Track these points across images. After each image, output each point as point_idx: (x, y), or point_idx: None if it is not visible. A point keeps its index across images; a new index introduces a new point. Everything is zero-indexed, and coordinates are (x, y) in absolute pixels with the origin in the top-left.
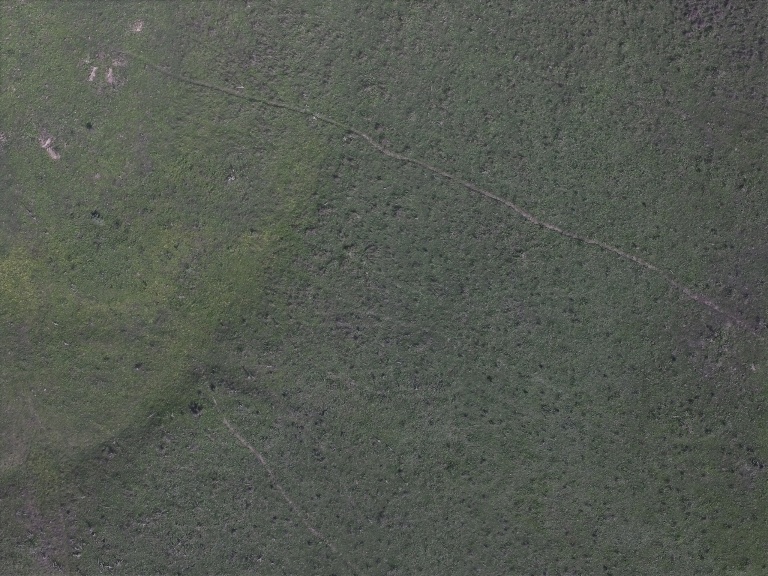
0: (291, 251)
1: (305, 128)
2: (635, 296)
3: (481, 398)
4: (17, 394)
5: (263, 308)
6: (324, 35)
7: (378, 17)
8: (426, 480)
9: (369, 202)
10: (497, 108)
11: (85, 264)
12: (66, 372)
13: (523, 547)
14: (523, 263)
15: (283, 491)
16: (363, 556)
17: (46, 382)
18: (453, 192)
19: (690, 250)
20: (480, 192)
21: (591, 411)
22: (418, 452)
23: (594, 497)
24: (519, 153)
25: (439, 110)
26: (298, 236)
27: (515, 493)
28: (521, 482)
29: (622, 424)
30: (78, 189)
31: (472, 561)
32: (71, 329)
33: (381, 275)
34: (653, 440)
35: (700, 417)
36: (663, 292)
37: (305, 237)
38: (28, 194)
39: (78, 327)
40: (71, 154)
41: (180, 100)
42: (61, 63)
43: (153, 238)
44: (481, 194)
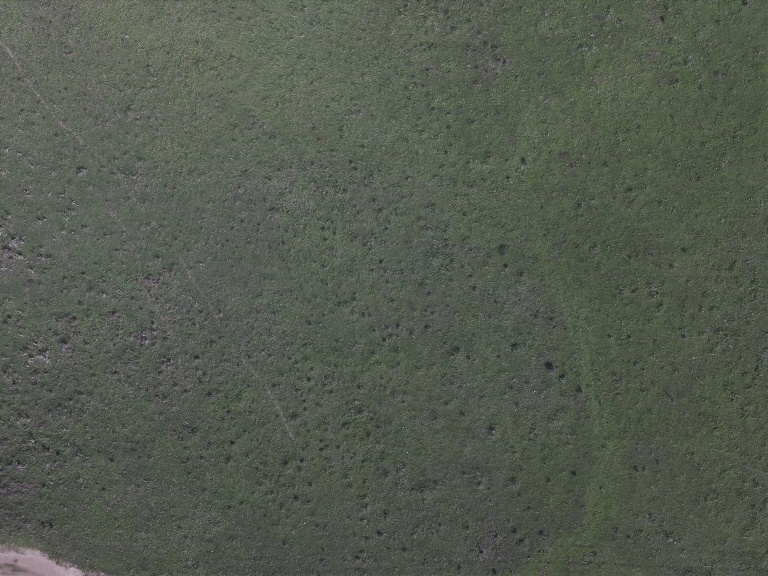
0: None
1: None
2: None
3: None
4: None
5: None
6: None
7: None
8: (174, 75)
9: None
10: None
11: None
12: None
13: (270, 141)
14: None
15: (31, 84)
16: (110, 148)
17: None
18: None
19: None
20: None
21: (339, 9)
22: (167, 48)
23: (341, 93)
24: None
25: None
26: None
27: (263, 89)
28: (269, 78)
29: (369, 21)
30: None
31: (219, 155)
32: None
33: None
34: (399, 37)
35: (446, 15)
36: None
37: None
38: None
39: None
40: None
41: None
42: None
43: None
44: None
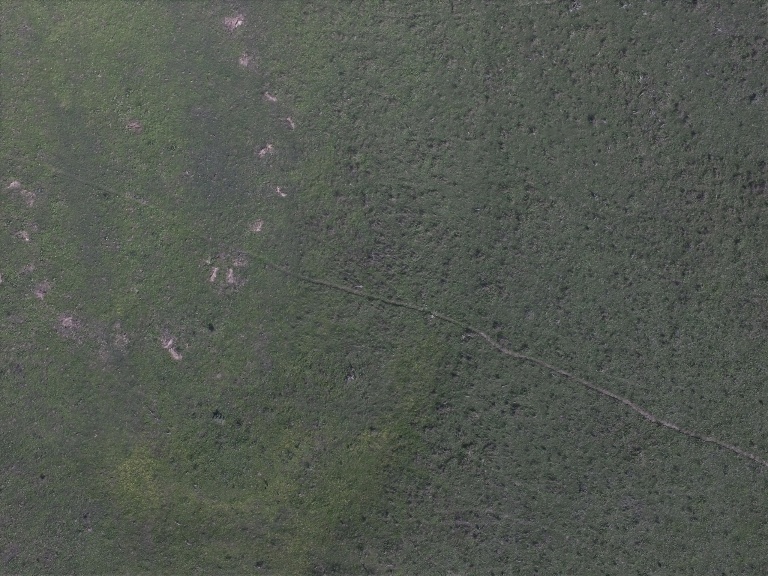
0: (410, 449)
1: (423, 326)
2: (753, 494)
3: None
4: None
5: (383, 506)
6: (442, 234)
7: (495, 216)
8: None
9: (487, 400)
10: (614, 306)
11: (207, 464)
12: (189, 572)
13: None
14: (641, 462)
15: None
16: None
17: None
18: (571, 390)
19: None
20: (597, 390)
21: None
22: None
23: None
24: (636, 351)
25: (556, 308)
26: (417, 434)
27: None
28: None
29: None
30: (200, 389)
31: None
32: (193, 528)
33: (500, 473)
34: None
35: None
36: None
37: (424, 435)
38: (151, 395)
39: (200, 526)
40: (193, 354)
41: (299, 299)
42: (182, 264)
43: (274, 438)
44: (599, 392)
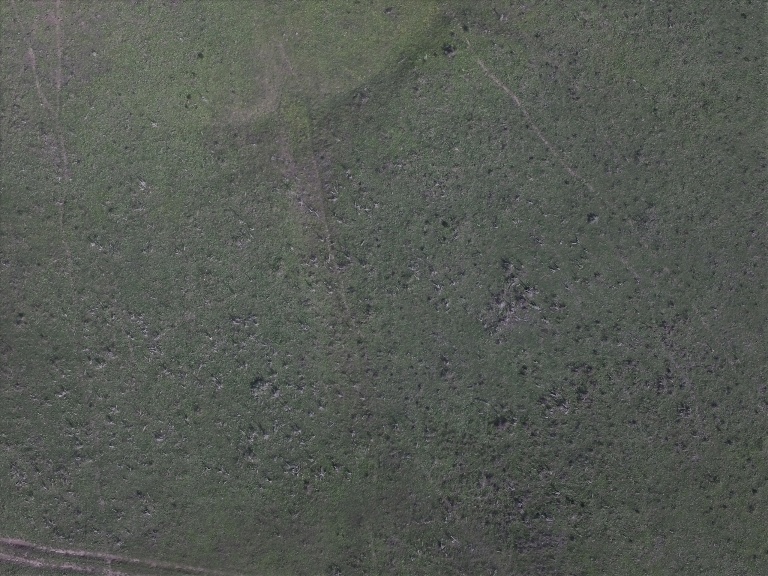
0: None
1: None
2: None
3: (735, 36)
4: (269, 39)
5: None
6: None
7: None
8: (681, 119)
9: None
10: None
11: None
12: (318, 15)
13: None
14: None
15: (539, 131)
16: (620, 195)
17: (298, 25)
18: None
19: None
20: None
21: None
22: (673, 91)
23: None
24: None
25: None
26: None
27: None
28: None
29: None
30: None
31: (730, 198)
32: None
33: None
34: None
35: None
36: None
37: None
38: None
39: None
40: None
41: None
42: None
43: None
44: None
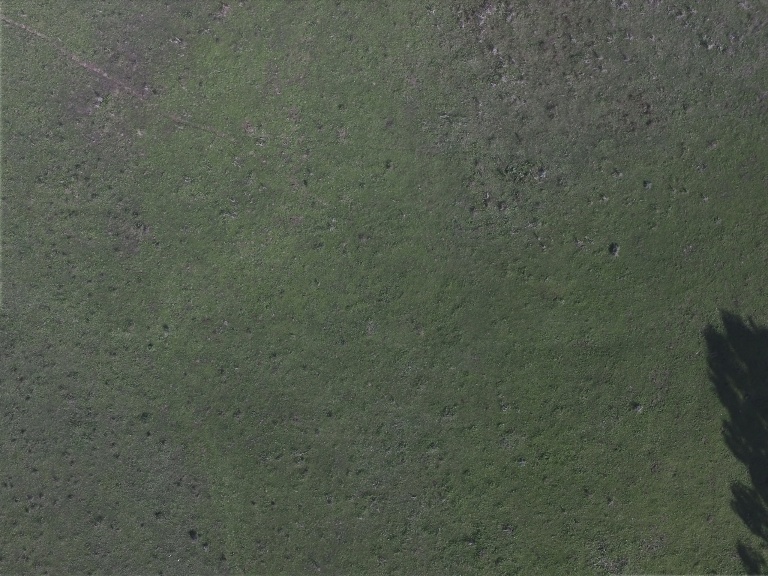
0: None
1: None
2: (23, 63)
3: None
4: None
5: None
6: None
7: None
8: None
9: None
10: None
11: None
12: None
13: None
14: None
15: None
16: None
17: None
18: None
19: (79, 17)
20: None
21: None
22: None
23: None
24: None
25: None
26: None
27: None
28: None
29: (9, 190)
30: None
31: None
32: None
33: None
34: (40, 205)
35: (87, 182)
36: (51, 59)
37: None
38: None
39: None
40: None
41: None
42: None
43: None
44: None
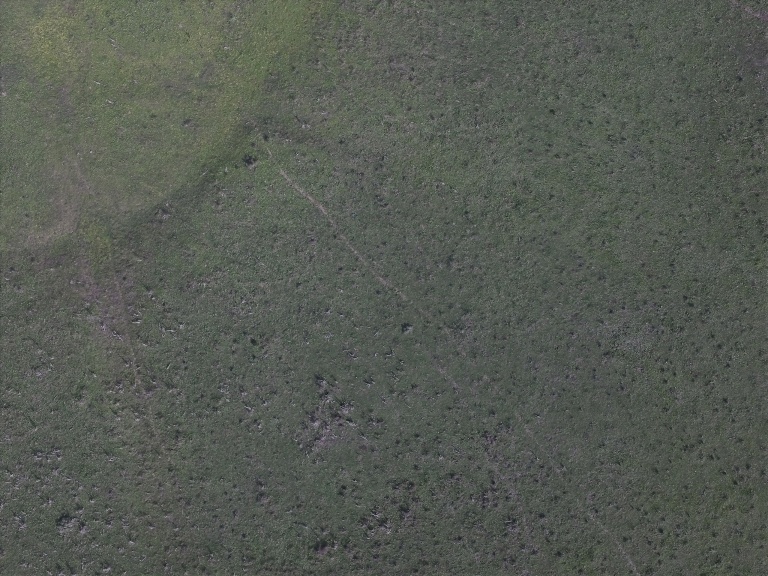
0: None
1: None
2: (696, 17)
3: (545, 133)
4: (62, 159)
5: (313, 55)
6: None
7: None
8: (494, 220)
9: None
10: None
11: (124, 19)
12: (112, 132)
13: (599, 282)
14: None
15: (347, 241)
16: (435, 302)
17: (92, 144)
18: None
19: None
20: None
21: (659, 138)
22: (484, 192)
23: (669, 226)
24: None
25: None
26: None
27: (587, 228)
28: (592, 216)
29: (692, 149)
30: None
31: (548, 300)
32: (114, 88)
33: (433, 13)
34: (725, 163)
35: None
36: (725, 11)
37: None
38: None
39: (121, 86)
40: None
41: None
42: None
43: None
44: None
